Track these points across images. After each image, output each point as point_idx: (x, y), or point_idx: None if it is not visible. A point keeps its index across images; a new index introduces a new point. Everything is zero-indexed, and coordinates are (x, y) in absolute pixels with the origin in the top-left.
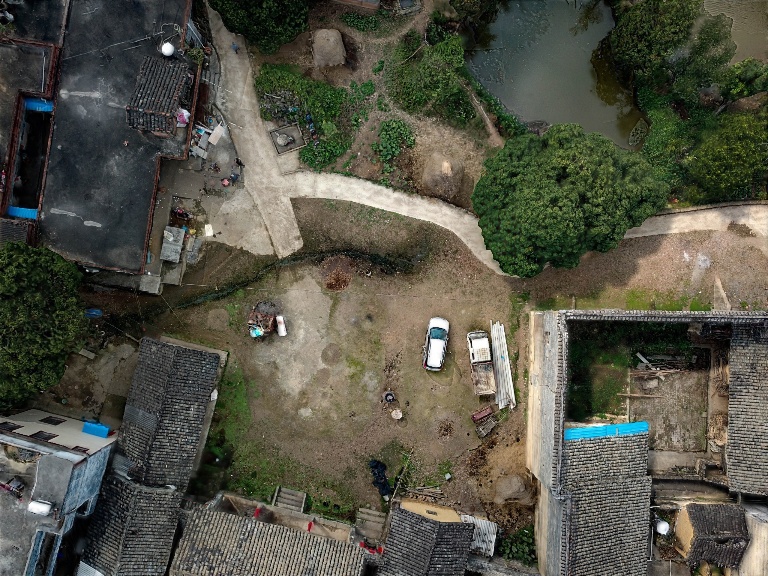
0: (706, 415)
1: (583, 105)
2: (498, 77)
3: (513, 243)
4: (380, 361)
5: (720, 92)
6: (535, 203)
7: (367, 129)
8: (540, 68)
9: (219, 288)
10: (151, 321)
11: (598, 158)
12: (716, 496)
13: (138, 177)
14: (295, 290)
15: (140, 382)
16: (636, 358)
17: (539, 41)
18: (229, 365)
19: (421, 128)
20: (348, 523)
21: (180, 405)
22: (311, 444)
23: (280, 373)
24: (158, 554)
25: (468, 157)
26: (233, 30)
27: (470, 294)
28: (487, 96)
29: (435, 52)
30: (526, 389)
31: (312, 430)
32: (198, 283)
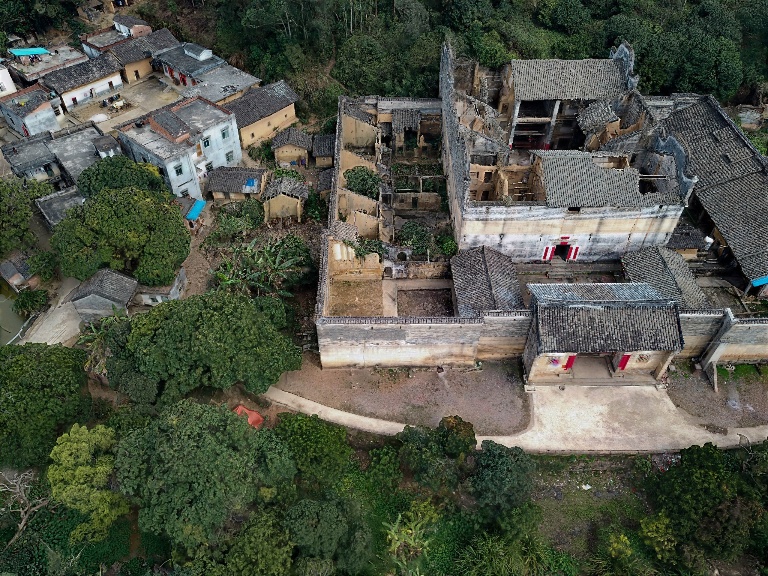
0: None
1: None
2: None
3: None
4: None
5: None
6: None
7: None
8: None
9: None
10: None
11: None
12: None
13: None
14: None
15: None
16: None
17: None
18: None
19: None
20: None
21: None
22: None
23: None
24: None
25: None
26: None
27: None
28: None
29: None
30: None
31: None
32: None
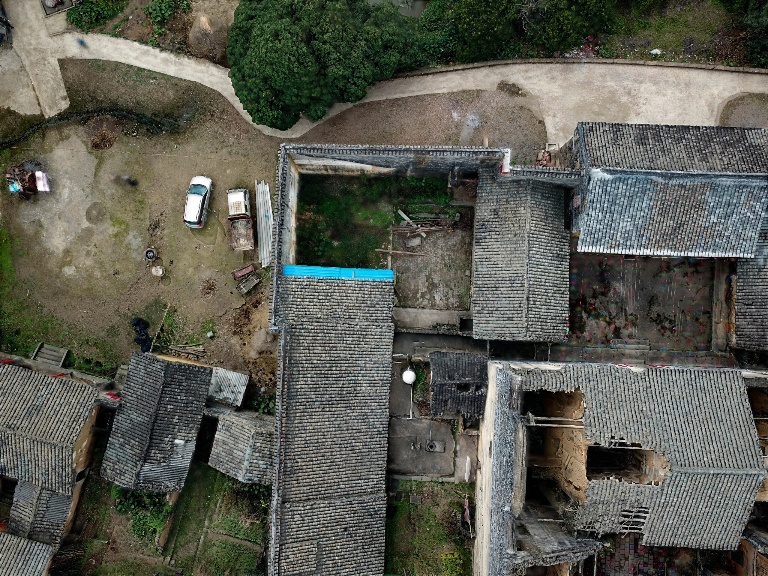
0: (469, 273)
1: None
2: None
3: (252, 87)
4: (144, 219)
5: None
6: (259, 38)
7: None
8: None
9: None
10: None
11: None
12: None
13: None
14: (61, 149)
15: None
16: (399, 216)
17: None
18: None
19: None
20: (107, 378)
21: None
22: (75, 302)
23: (45, 231)
24: None
25: None
26: None
27: (236, 154)
28: None
29: None
30: None
31: (76, 287)
32: None
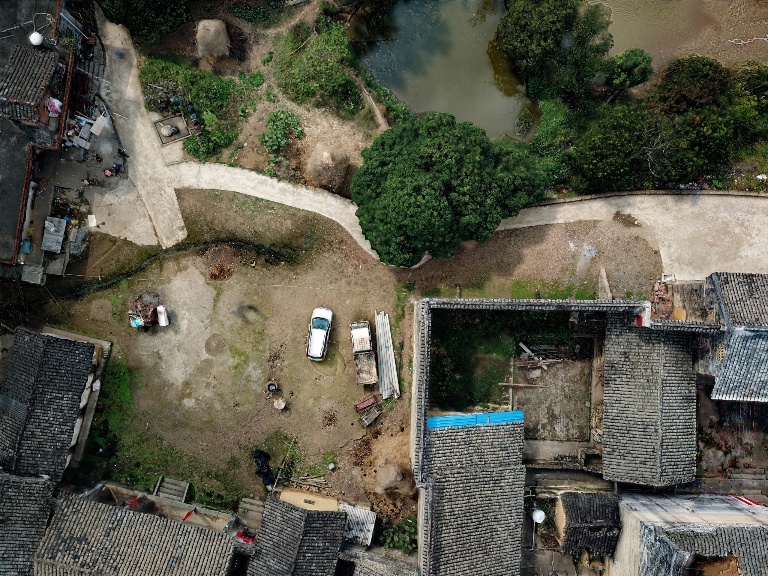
0: (589, 405)
1: (475, 96)
2: (390, 68)
3: (385, 232)
4: (264, 351)
5: (606, 82)
6: (400, 192)
7: (255, 120)
8: (432, 59)
9: (103, 278)
10: (34, 311)
11: (464, 147)
12: (598, 485)
13: (10, 167)
14: (179, 280)
15: (14, 372)
16: (519, 348)
17: (431, 32)
18: (113, 355)
19: (310, 119)
20: (230, 513)
21: (52, 395)
22: (195, 434)
23: (164, 363)
24: (30, 543)
25: (357, 148)
26: (113, 20)
27: (355, 284)
28: (377, 87)
29: (319, 42)
30: (411, 379)
31: (196, 420)
32: (81, 273)
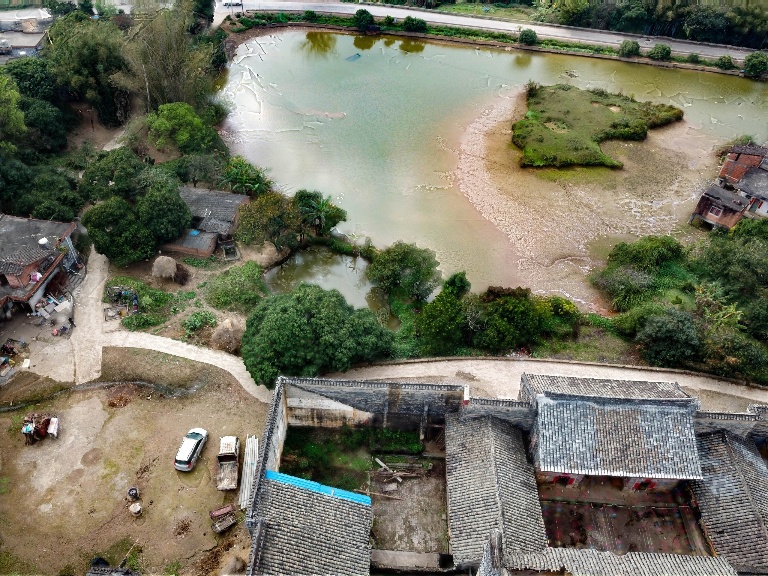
0: (446, 517)
1: None
2: None
3: (260, 352)
4: (136, 464)
5: None
6: None
7: (182, 315)
8: None
9: (14, 403)
10: None
11: None
12: None
13: None
14: (80, 407)
15: None
16: (376, 465)
17: (322, 280)
18: None
19: (224, 317)
20: None
21: None
22: (38, 540)
23: (36, 472)
24: None
25: None
26: (99, 252)
27: (234, 415)
28: None
29: None
30: None
31: (45, 525)
32: None
